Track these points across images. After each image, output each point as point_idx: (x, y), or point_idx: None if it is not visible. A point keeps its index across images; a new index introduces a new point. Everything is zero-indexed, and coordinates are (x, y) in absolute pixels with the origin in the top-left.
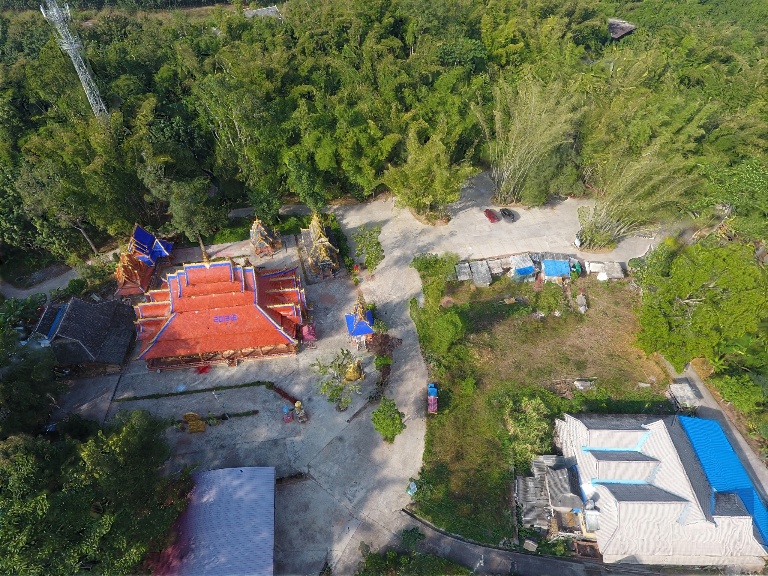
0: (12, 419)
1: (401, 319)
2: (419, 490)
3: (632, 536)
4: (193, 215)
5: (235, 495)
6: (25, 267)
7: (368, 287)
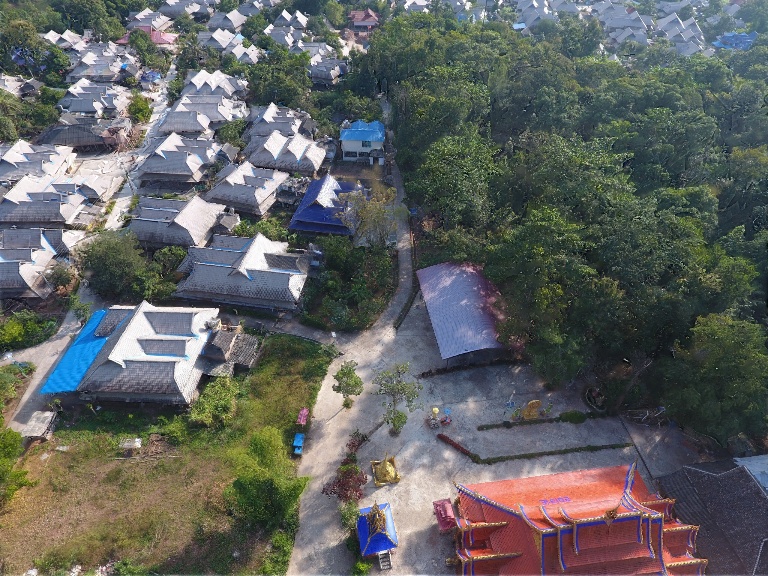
0: None
1: (317, 567)
2: None
3: None
4: None
5: (464, 335)
6: None
7: None
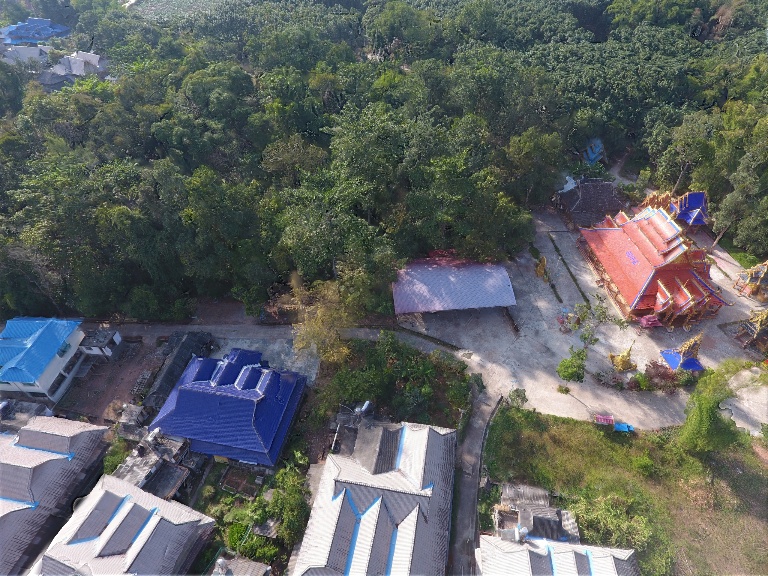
0: (517, 183)
1: None
2: (516, 396)
3: (499, 568)
4: (738, 214)
5: (493, 284)
6: (638, 170)
7: (747, 379)
